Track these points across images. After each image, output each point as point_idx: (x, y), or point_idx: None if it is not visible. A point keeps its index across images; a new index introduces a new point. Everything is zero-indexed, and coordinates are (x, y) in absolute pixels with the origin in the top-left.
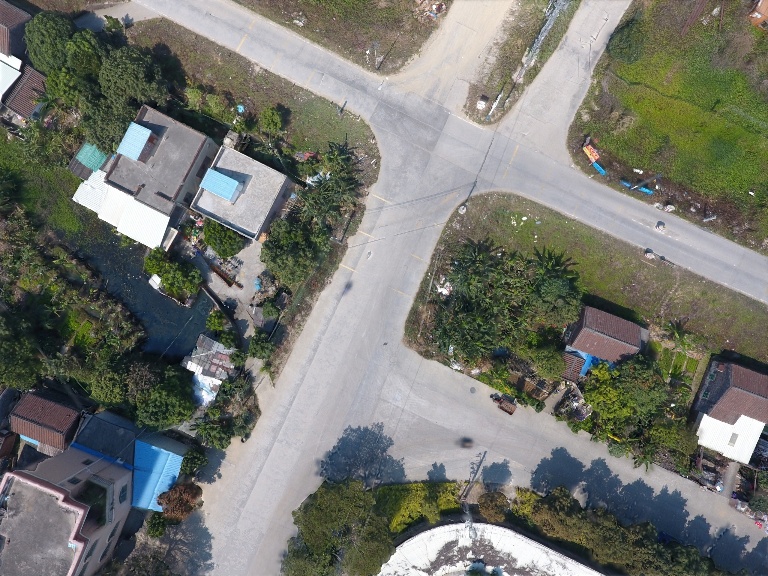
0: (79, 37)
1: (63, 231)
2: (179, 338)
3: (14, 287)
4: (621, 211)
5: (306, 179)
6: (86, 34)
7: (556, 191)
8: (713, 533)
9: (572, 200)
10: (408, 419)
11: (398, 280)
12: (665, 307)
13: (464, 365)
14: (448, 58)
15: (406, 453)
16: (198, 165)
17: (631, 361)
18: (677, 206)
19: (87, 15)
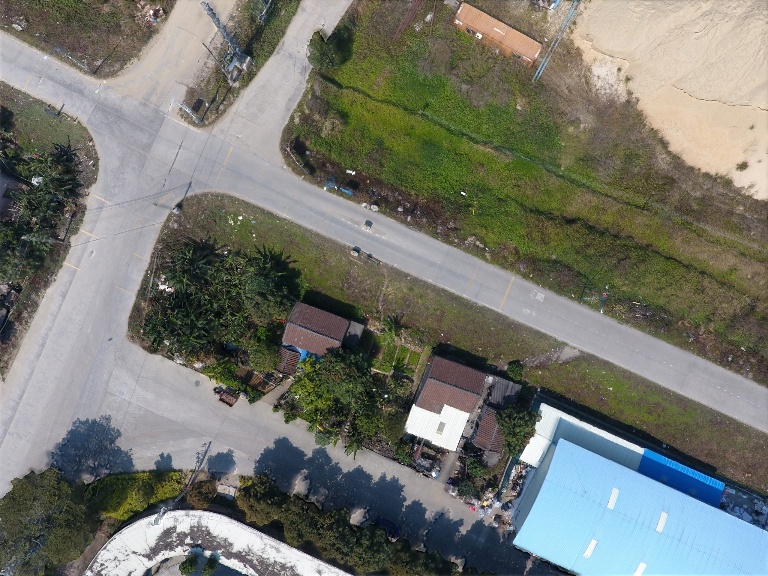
0: None
1: None
2: None
3: None
4: (331, 211)
5: (31, 180)
6: None
7: (268, 191)
8: (429, 517)
9: (284, 200)
10: (135, 411)
11: (120, 278)
12: (382, 302)
13: None
14: (168, 62)
15: (134, 444)
16: None
17: (329, 354)
18: (384, 206)
19: None
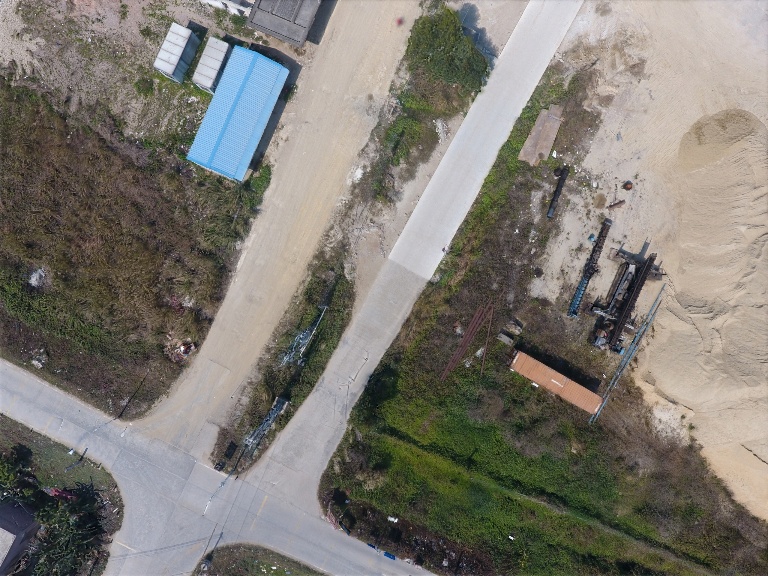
0: None
1: None
2: None
3: None
4: (371, 565)
5: None
6: None
7: (305, 544)
8: None
9: (321, 553)
10: None
11: None
12: None
13: None
14: (199, 398)
15: None
16: None
17: None
18: (428, 561)
19: None
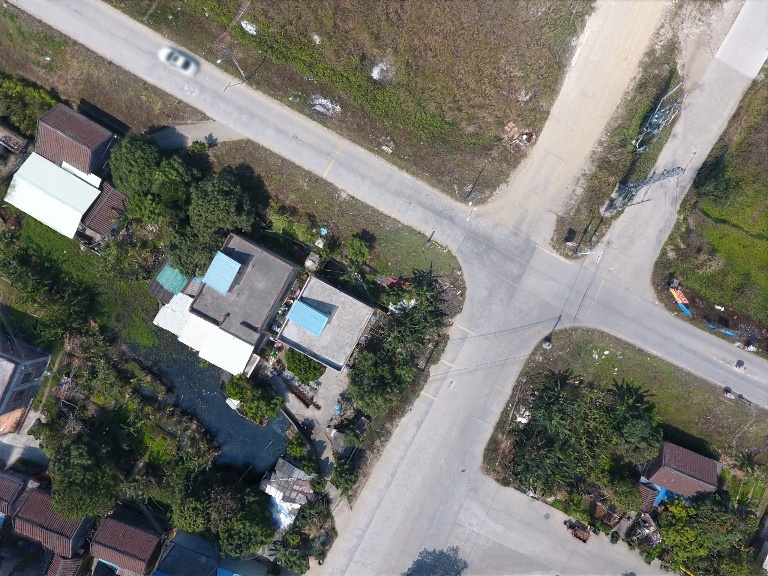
0: (167, 166)
1: (137, 345)
2: (254, 455)
3: (88, 402)
4: (702, 349)
5: (389, 305)
6: (174, 163)
7: (639, 327)
8: None
9: (655, 337)
10: (483, 543)
11: (479, 409)
12: (738, 439)
13: (541, 494)
14: (536, 188)
15: (479, 575)
16: (283, 292)
17: (709, 501)
18: (757, 346)
19: (167, 129)
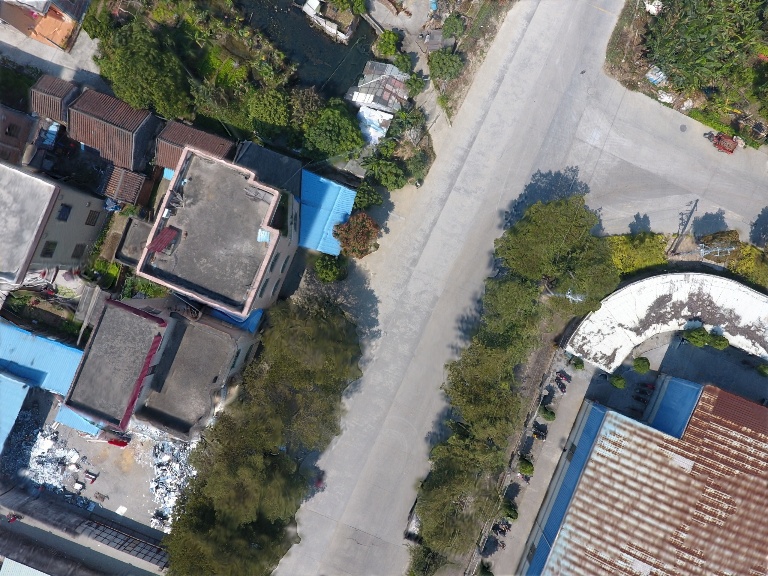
0: None
1: None
2: (334, 80)
3: None
4: None
5: None
6: None
7: None
8: None
9: None
10: (607, 162)
11: None
12: None
13: (677, 94)
14: None
15: (604, 202)
16: None
17: None
18: None
19: None
